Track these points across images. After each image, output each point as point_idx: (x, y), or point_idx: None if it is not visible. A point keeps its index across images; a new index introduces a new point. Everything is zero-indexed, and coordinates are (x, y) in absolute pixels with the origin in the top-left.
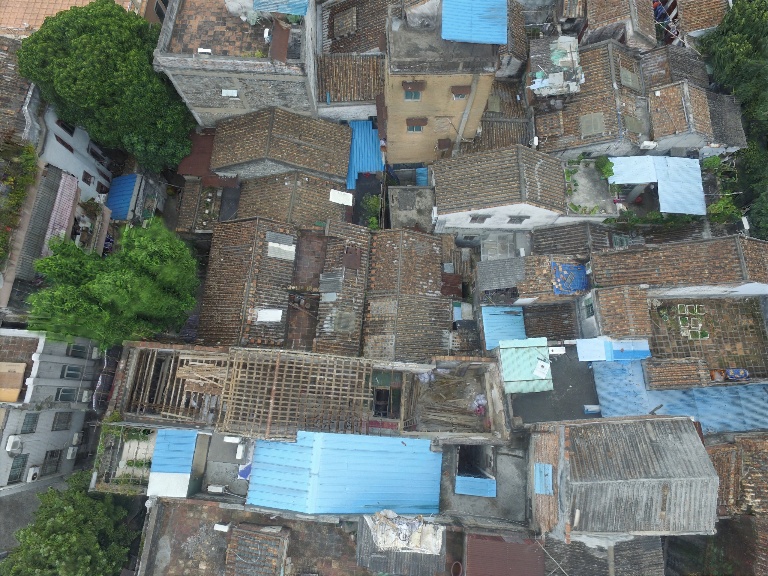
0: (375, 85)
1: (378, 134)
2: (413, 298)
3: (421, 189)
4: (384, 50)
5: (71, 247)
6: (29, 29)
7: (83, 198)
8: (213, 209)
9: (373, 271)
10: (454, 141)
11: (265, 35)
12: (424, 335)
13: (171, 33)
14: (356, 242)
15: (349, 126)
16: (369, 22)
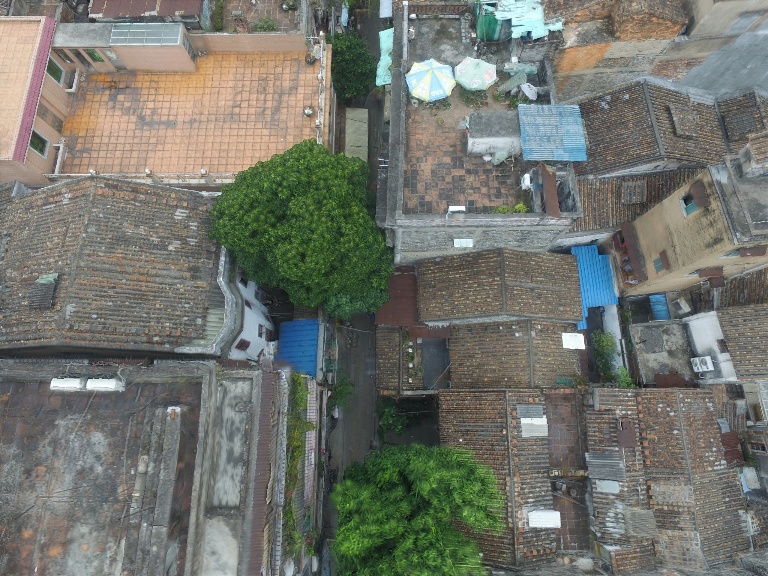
0: (614, 210)
1: (634, 275)
2: (704, 477)
3: (667, 325)
4: (704, 204)
5: (360, 502)
6: (205, 175)
7: (255, 353)
8: (416, 361)
9: (645, 443)
10: (727, 277)
11: (527, 183)
12: (723, 523)
13: (403, 183)
14: (626, 411)
15: (571, 253)
16: (604, 138)
